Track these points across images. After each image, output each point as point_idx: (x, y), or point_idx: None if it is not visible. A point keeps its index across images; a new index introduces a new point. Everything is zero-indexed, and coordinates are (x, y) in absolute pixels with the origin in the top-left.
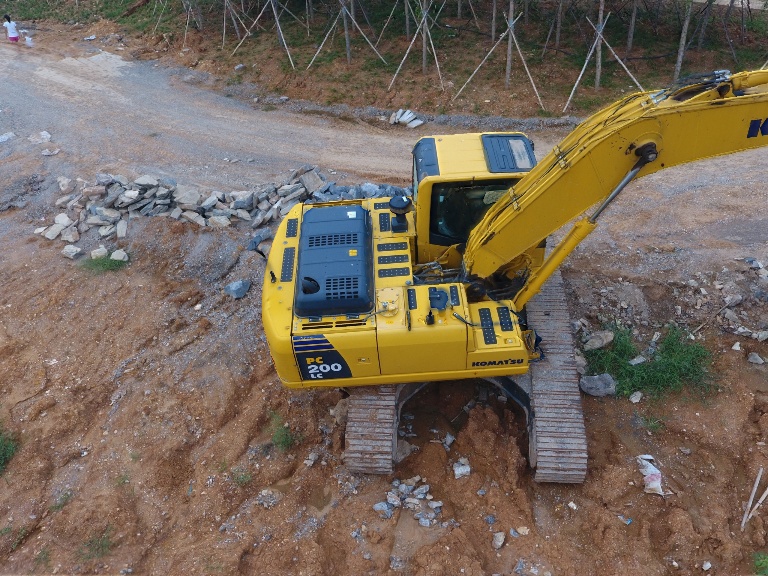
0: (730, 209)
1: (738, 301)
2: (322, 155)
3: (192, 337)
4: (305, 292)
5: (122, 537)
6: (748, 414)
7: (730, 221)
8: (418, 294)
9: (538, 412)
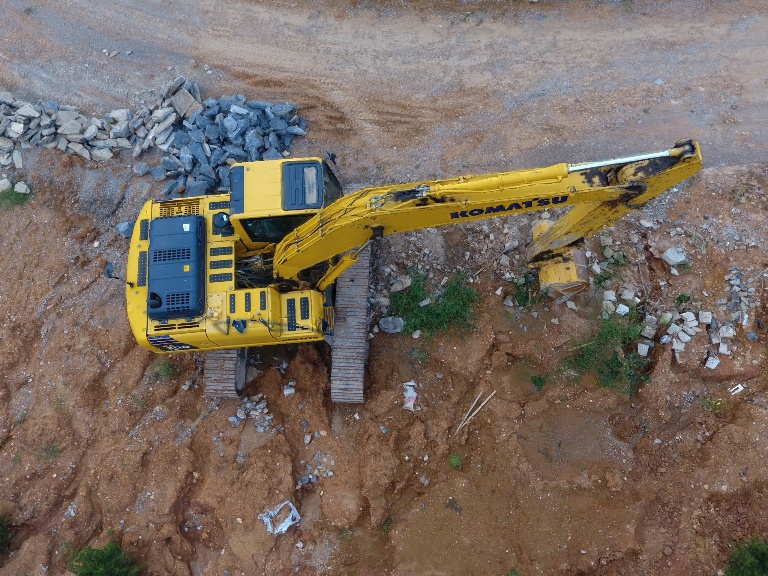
0: (552, 131)
1: (515, 247)
2: (200, 40)
3: (94, 277)
4: (151, 307)
5: (65, 446)
6: (487, 350)
7: (547, 147)
8: (237, 299)
9: (334, 362)
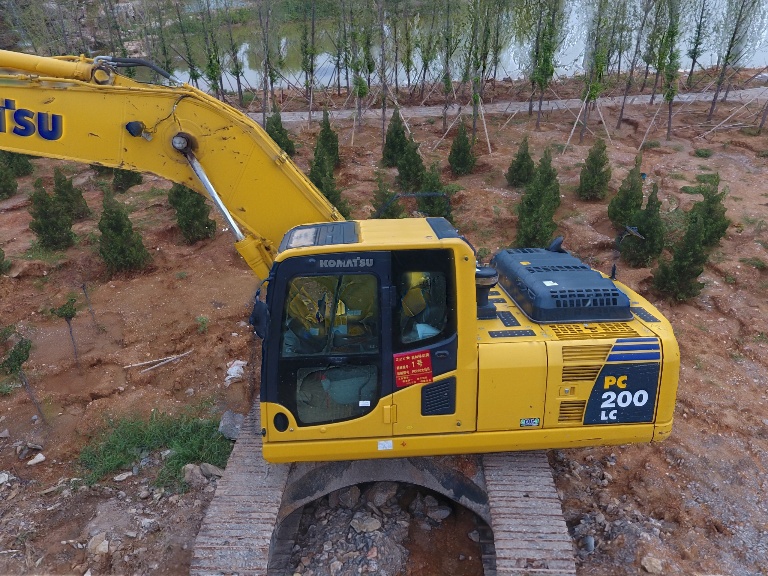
0: None
1: None
2: None
3: None
4: None
5: None
6: None
7: None
8: None
9: None
